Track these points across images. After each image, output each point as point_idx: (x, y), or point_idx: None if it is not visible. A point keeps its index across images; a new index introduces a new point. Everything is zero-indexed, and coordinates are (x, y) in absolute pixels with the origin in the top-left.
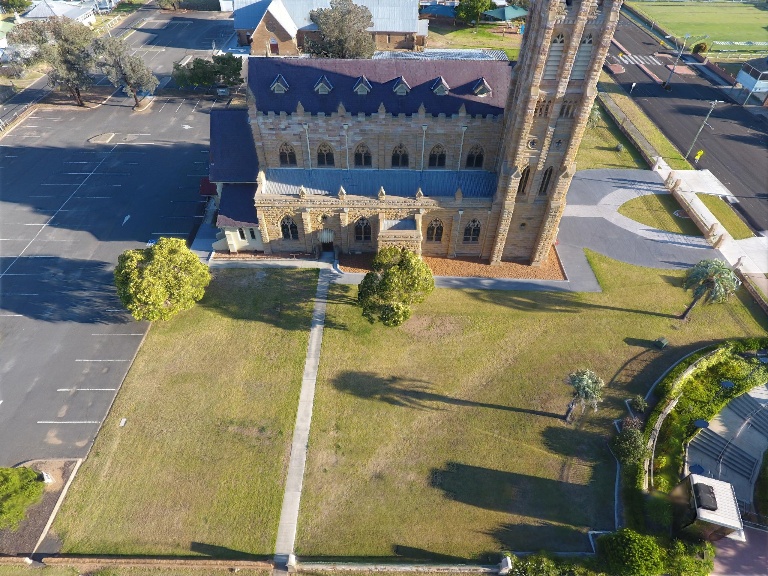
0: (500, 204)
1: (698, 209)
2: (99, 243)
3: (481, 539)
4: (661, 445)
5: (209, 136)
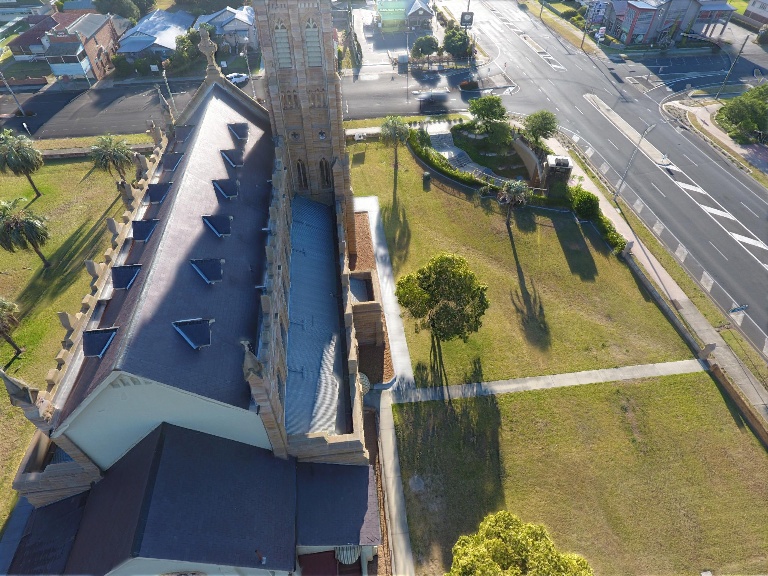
0: None
1: None
2: None
3: (614, 264)
4: None
5: None
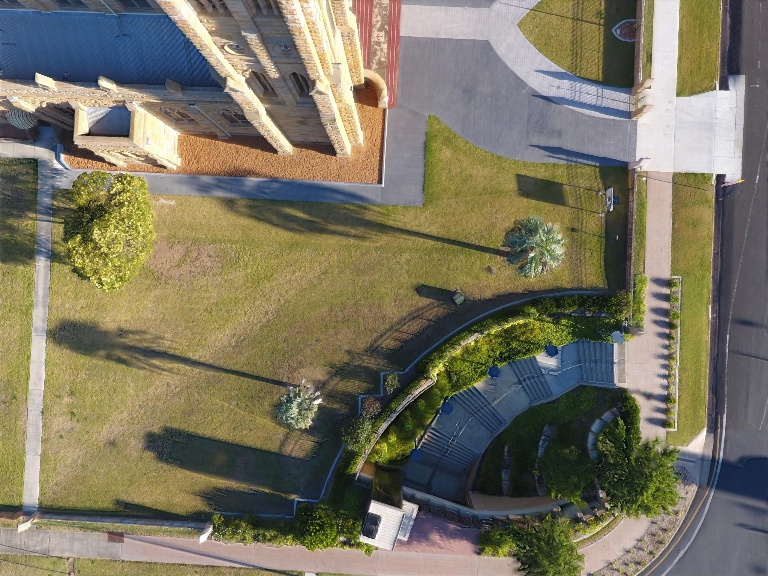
0: None
1: (661, 17)
2: None
3: (198, 501)
4: (404, 416)
5: None
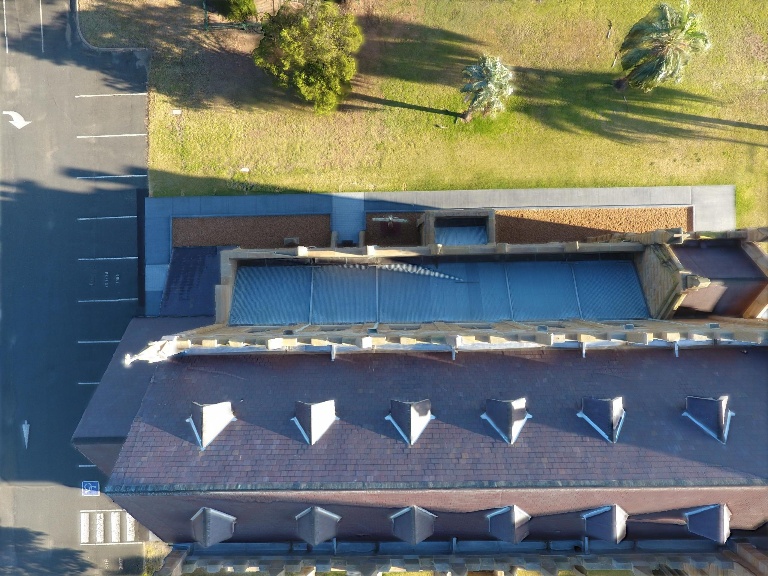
0: None
1: None
2: (11, 491)
3: None
4: None
5: (74, 158)
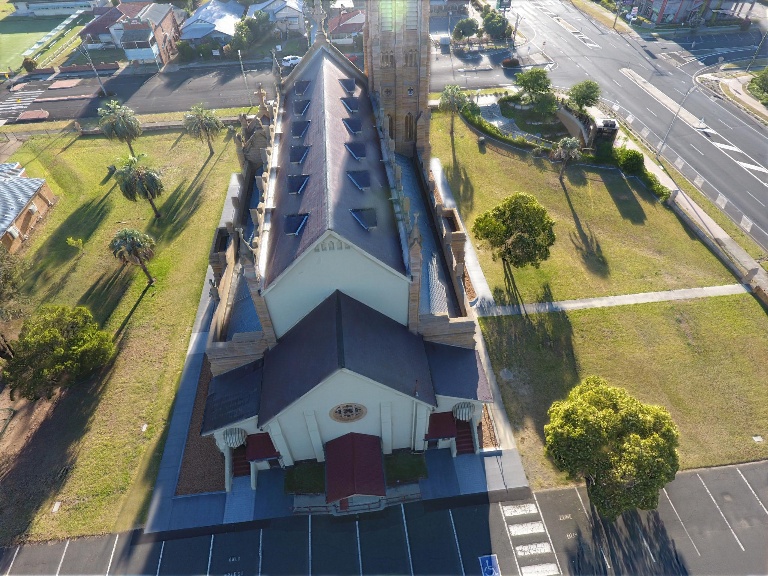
0: (424, 150)
1: None
2: None
3: (660, 210)
4: None
5: None
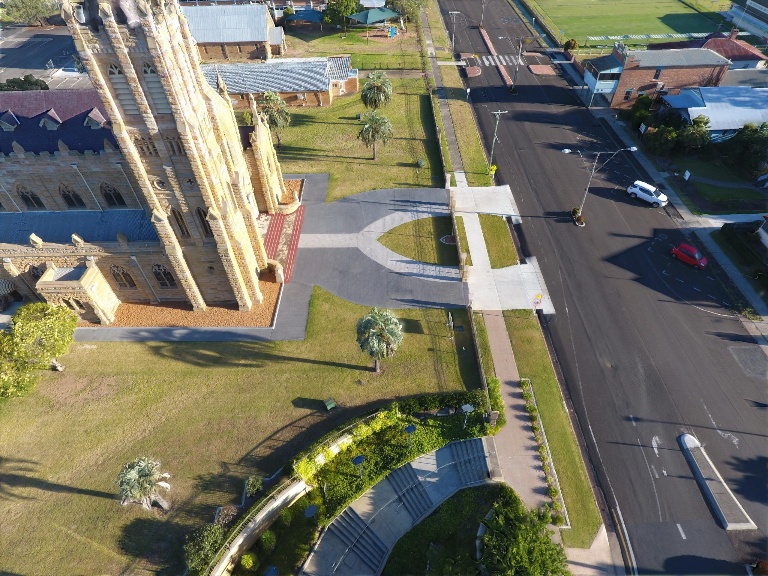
0: None
1: (471, 233)
2: None
3: None
4: None
5: None
